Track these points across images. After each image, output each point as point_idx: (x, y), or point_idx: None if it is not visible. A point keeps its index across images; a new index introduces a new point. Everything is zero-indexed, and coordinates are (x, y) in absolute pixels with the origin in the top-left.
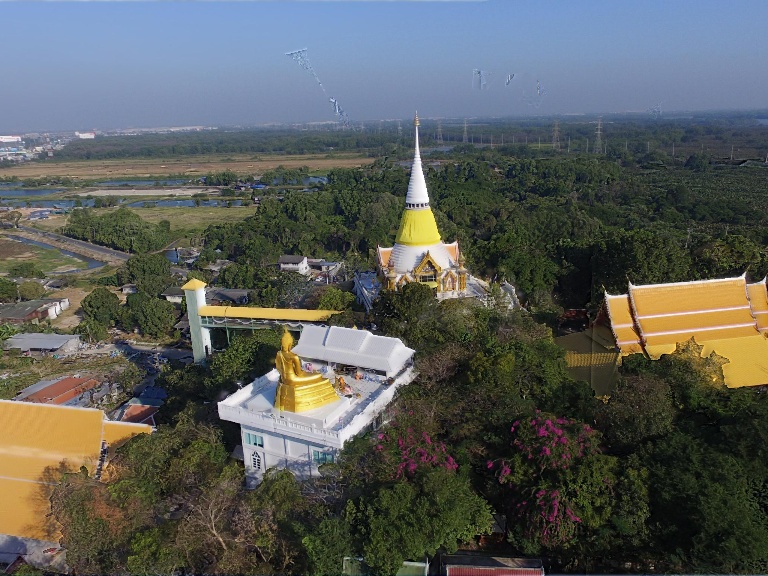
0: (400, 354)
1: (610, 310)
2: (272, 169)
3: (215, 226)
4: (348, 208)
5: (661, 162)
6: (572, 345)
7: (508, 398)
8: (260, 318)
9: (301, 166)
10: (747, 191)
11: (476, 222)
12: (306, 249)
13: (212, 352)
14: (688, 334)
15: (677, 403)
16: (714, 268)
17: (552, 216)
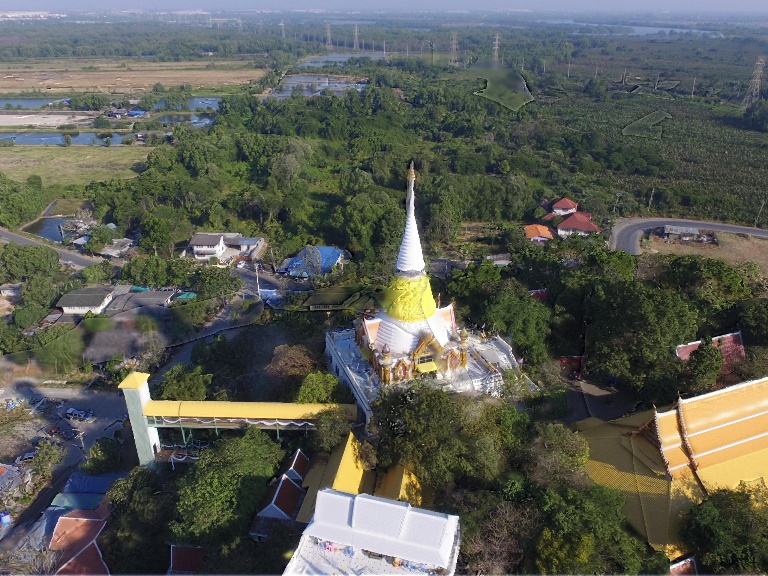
0: (447, 533)
1: (659, 430)
2: (148, 87)
3: (99, 183)
4: (253, 154)
5: (561, 87)
6: (607, 456)
7: None
8: (225, 417)
9: (182, 84)
10: None
11: (397, 174)
12: (217, 220)
13: (161, 449)
14: (735, 448)
15: (758, 570)
16: (706, 308)
17: (485, 181)
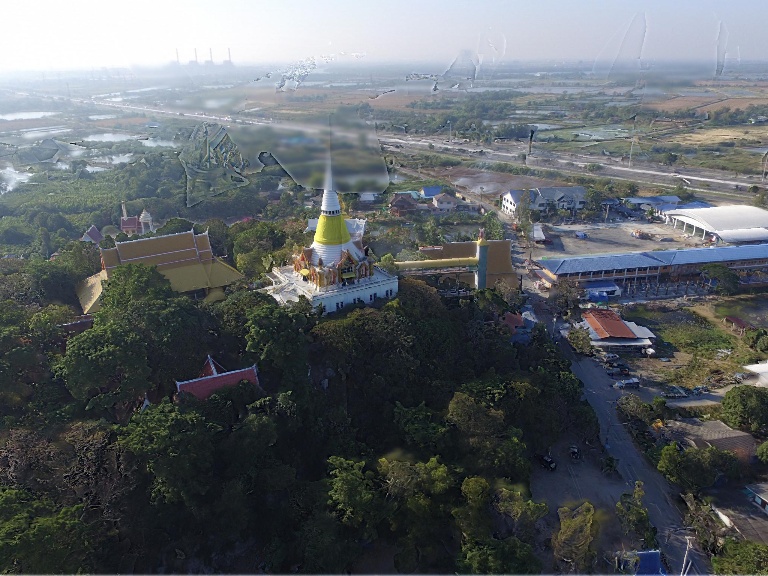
0: None
1: None
2: None
3: None
4: None
5: None
6: (226, 266)
7: None
8: None
9: None
10: None
11: None
12: None
13: None
14: None
15: None
16: None
17: None
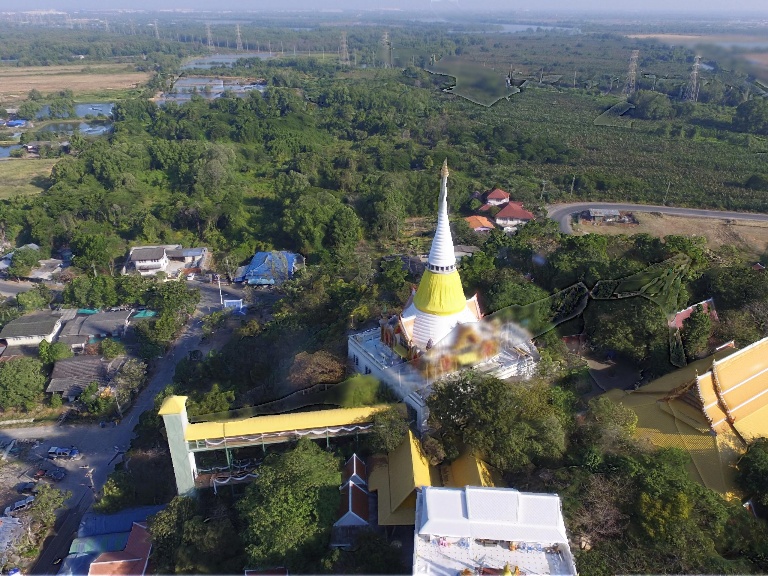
0: None
1: (701, 392)
2: (23, 94)
3: (1, 200)
4: (168, 161)
5: None
6: (649, 421)
7: (727, 569)
8: (274, 431)
9: (62, 89)
10: (549, 121)
11: (325, 174)
12: (151, 232)
13: (198, 474)
14: (757, 400)
15: None
16: None
17: (423, 176)
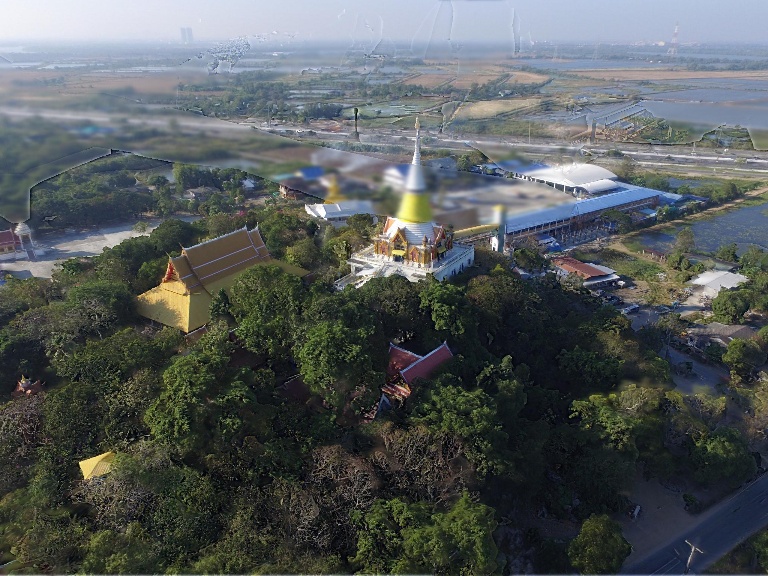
0: None
1: None
2: None
3: None
4: None
5: None
6: None
7: None
8: None
9: None
10: None
11: None
12: None
13: None
14: None
15: None
16: None
17: None
